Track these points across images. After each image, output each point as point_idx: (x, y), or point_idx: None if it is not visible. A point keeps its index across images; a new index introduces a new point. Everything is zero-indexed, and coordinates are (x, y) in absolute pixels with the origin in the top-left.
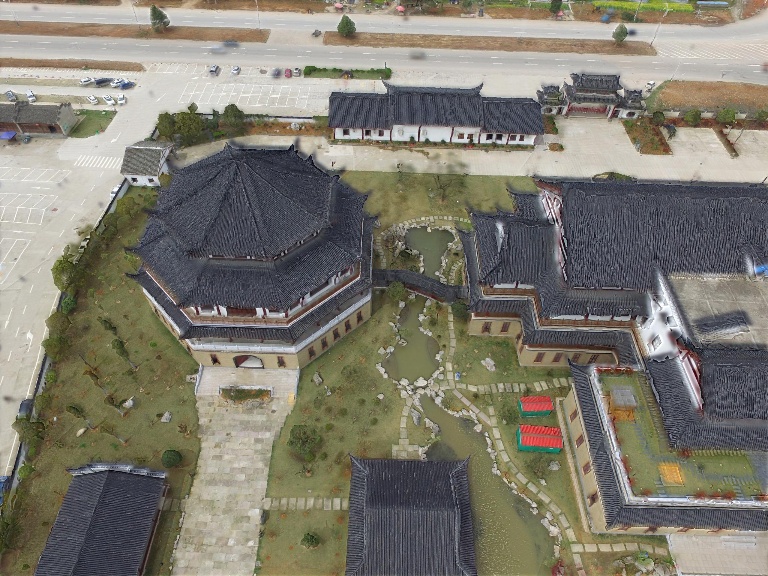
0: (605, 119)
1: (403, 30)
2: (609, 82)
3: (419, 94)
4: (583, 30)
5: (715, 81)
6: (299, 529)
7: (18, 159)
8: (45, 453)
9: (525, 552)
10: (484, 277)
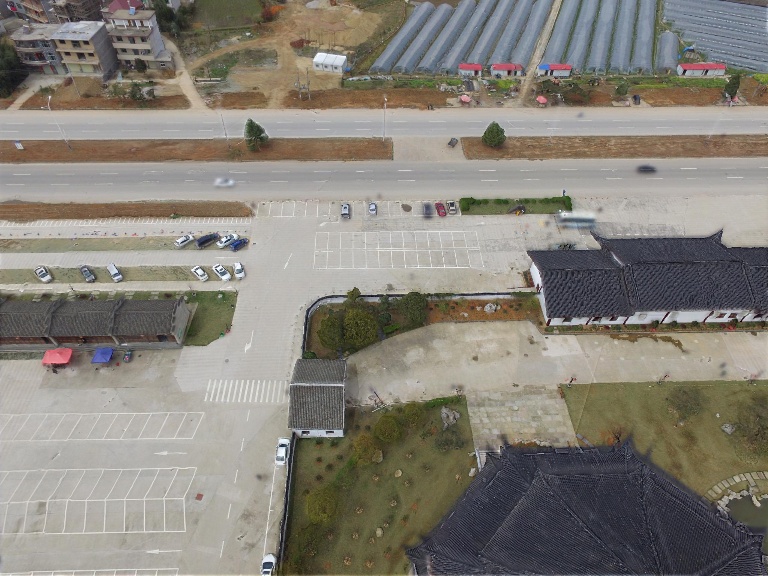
0: None
1: (554, 130)
2: None
3: (665, 263)
4: (767, 119)
5: None
6: None
7: (122, 395)
8: None
9: None
10: None
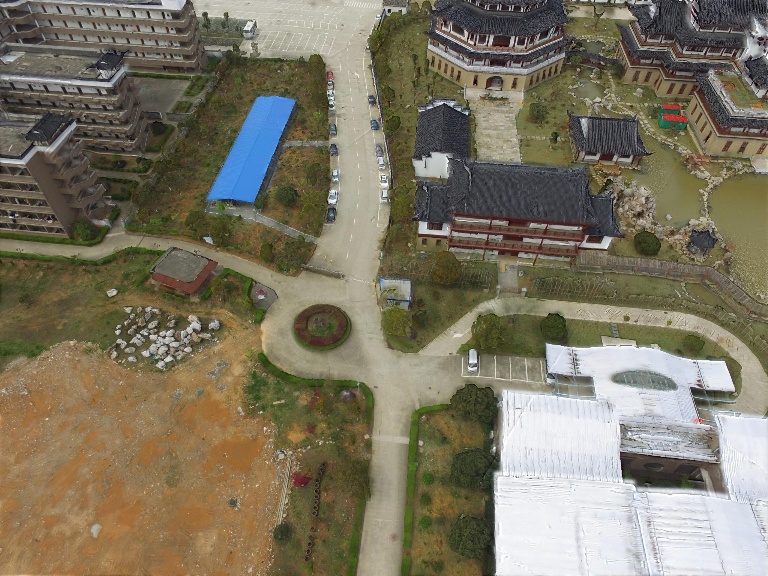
0: None
1: None
2: None
3: None
4: None
5: None
6: (540, 145)
7: (307, 1)
8: None
9: (667, 161)
10: (644, 29)
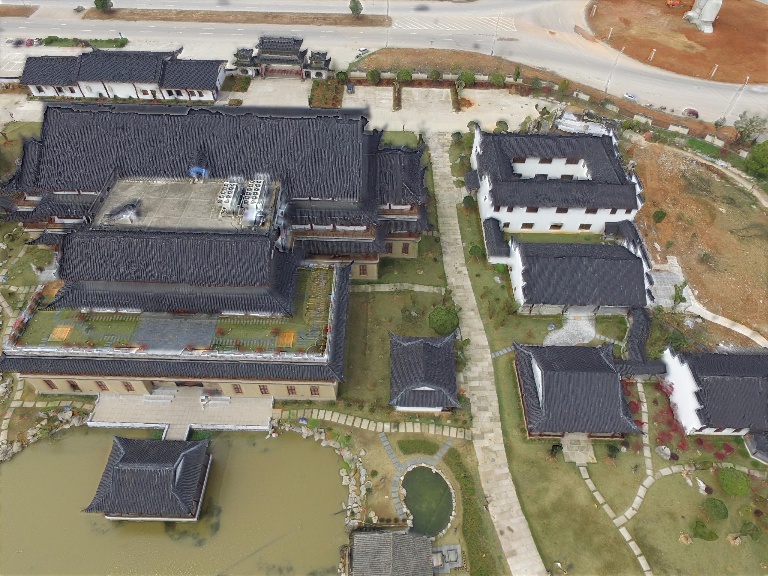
0: (300, 80)
1: (165, 6)
2: (288, 44)
3: (105, 54)
4: (337, 6)
5: (428, 48)
6: None
7: None
8: None
9: None
10: (1, 188)
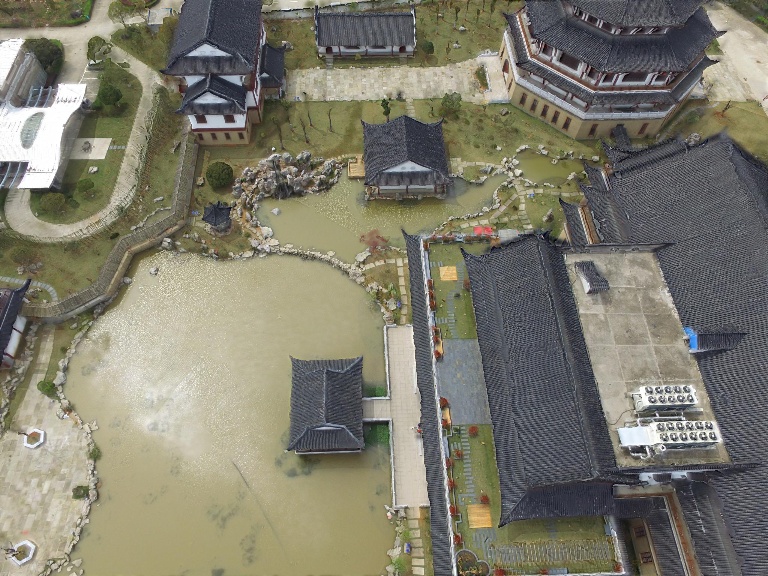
0: None
1: None
2: None
3: None
4: None
5: None
6: (396, 115)
7: None
8: (425, 8)
9: (394, 233)
10: None
